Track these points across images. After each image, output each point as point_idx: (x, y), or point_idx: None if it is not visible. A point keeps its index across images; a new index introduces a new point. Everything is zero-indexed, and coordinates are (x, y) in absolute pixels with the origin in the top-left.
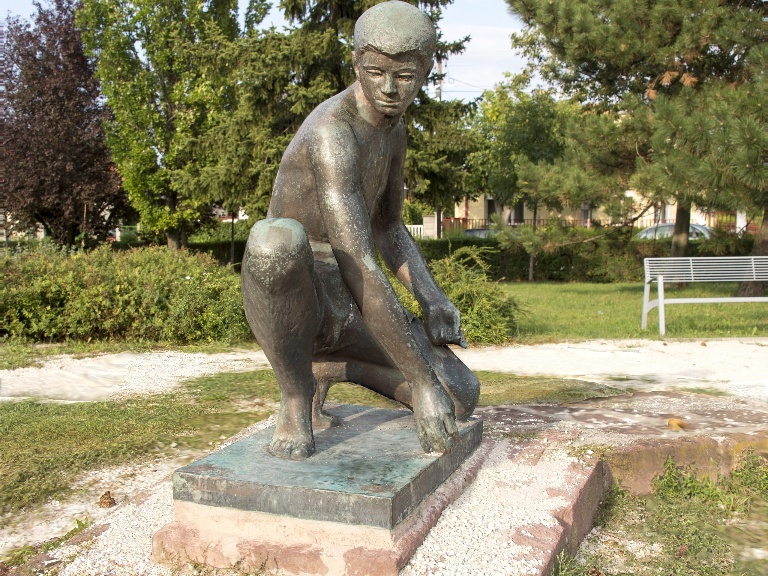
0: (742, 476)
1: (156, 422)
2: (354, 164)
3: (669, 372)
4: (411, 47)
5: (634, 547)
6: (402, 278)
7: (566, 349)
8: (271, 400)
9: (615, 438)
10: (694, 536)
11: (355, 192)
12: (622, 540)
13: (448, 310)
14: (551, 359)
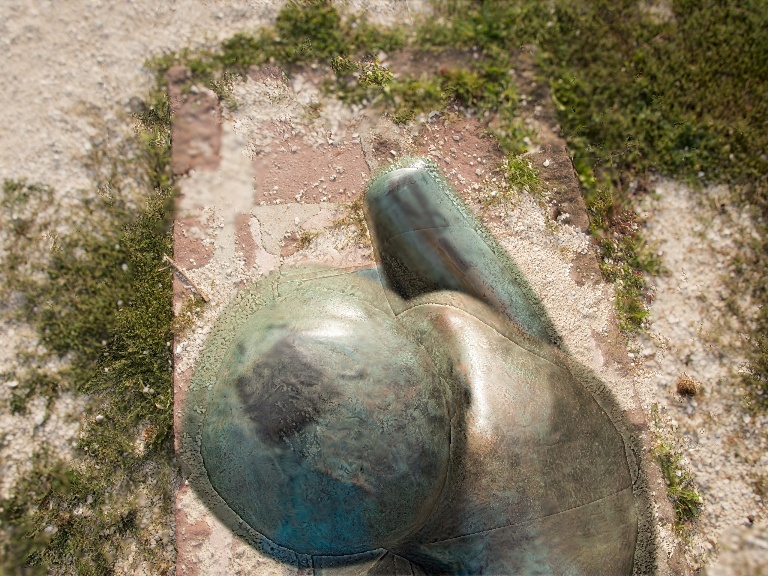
0: None
1: None
2: None
3: None
4: None
5: (141, 572)
6: None
7: None
8: None
9: None
10: None
11: None
12: None
13: None
14: None
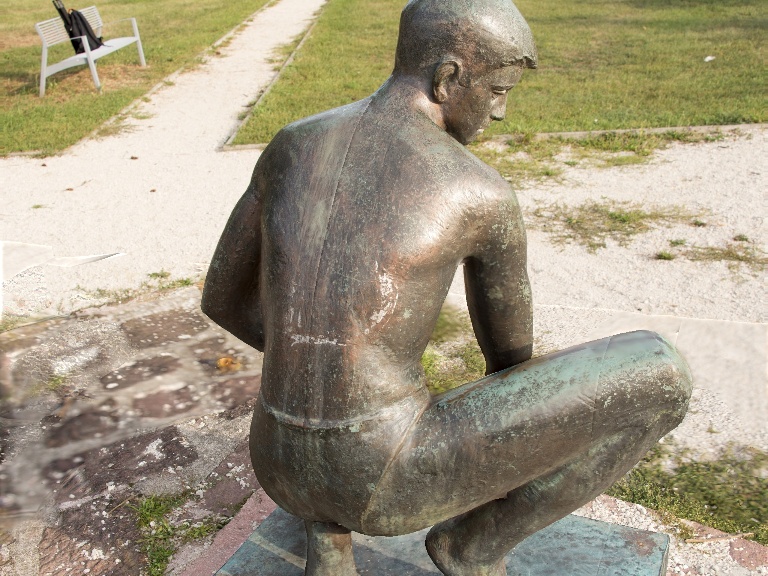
0: None
1: None
2: None
3: None
4: None
5: None
6: None
7: None
8: None
9: None
10: None
11: None
12: None
13: None
14: None
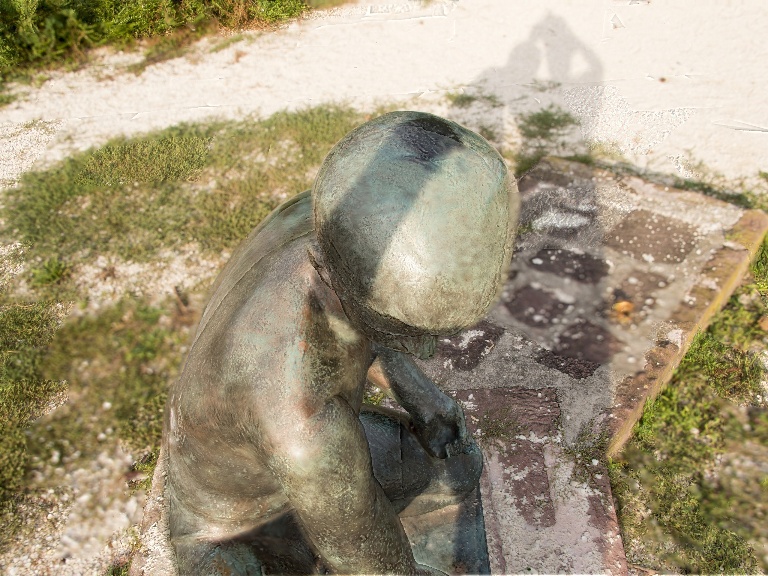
0: (692, 362)
1: (6, 385)
2: (370, 480)
3: (495, 65)
4: (487, 301)
5: None
6: (374, 381)
7: (373, 20)
8: (120, 260)
9: (596, 397)
10: (720, 550)
11: (376, 512)
12: (652, 575)
13: (449, 416)
14: (369, 51)
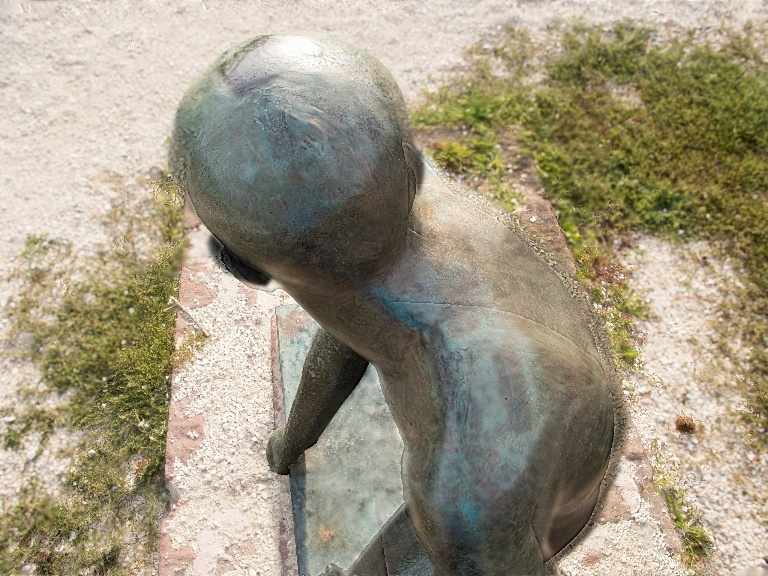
0: None
1: None
2: None
3: None
4: None
5: None
6: None
7: None
8: None
9: None
10: None
11: None
12: None
13: None
14: None
